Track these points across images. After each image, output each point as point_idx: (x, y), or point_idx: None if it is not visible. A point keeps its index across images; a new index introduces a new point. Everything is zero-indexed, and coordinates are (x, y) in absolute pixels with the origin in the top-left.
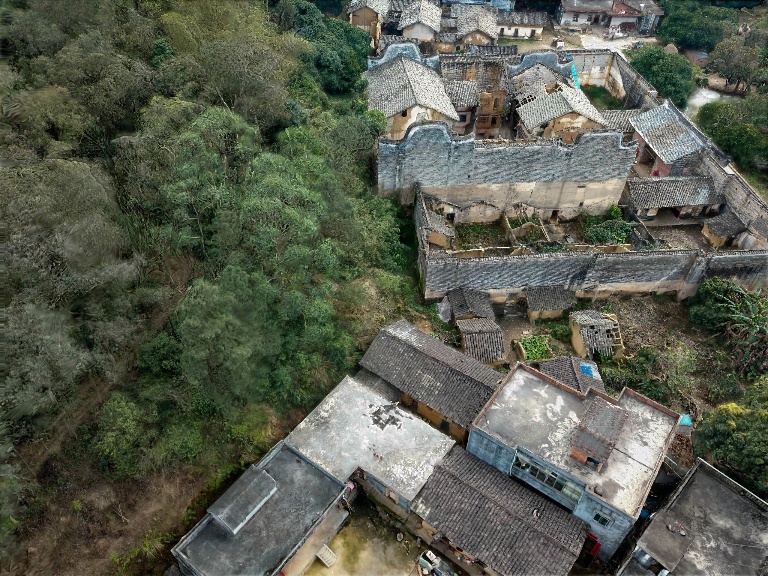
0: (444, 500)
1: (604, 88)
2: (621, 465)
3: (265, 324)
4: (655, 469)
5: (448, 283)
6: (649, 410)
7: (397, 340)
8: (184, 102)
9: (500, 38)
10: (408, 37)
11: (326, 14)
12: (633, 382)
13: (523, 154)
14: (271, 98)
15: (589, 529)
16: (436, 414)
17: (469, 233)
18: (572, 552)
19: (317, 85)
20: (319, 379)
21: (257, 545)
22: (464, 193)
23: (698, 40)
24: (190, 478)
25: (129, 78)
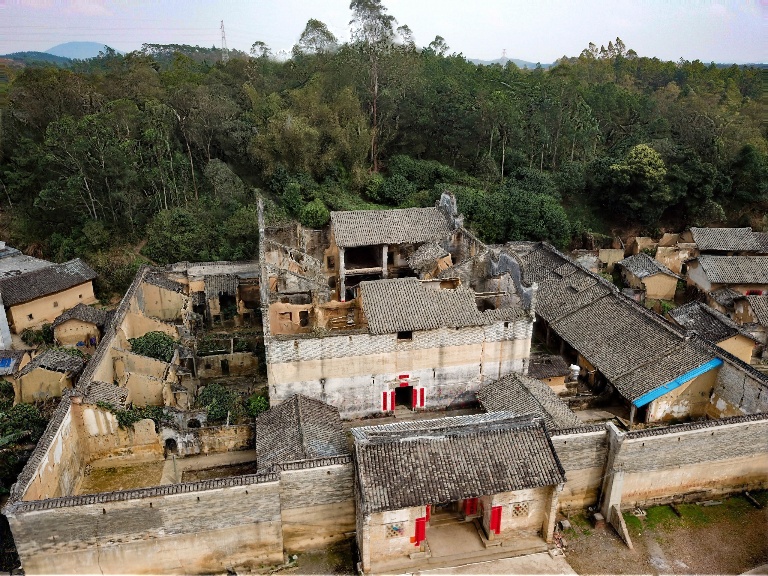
0: None
1: None
2: None
3: None
4: None
5: None
6: None
7: None
8: None
9: None
10: None
11: (658, 226)
12: None
13: None
14: None
15: None
16: None
17: None
18: None
19: None
20: None
21: None
22: None
23: None
24: None
25: (178, 96)
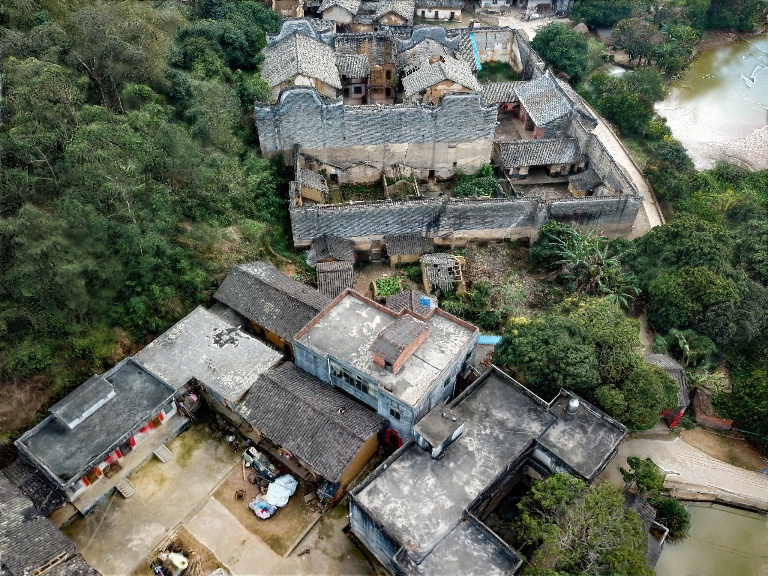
0: (263, 402)
1: (508, 64)
2: (416, 368)
3: (107, 252)
4: (442, 370)
5: (313, 231)
6: (453, 326)
7: (246, 274)
8: (40, 61)
9: (422, 20)
10: (326, 19)
11: None
12: (470, 313)
13: (391, 116)
14: (145, 65)
15: (387, 423)
16: (272, 335)
17: (352, 192)
18: (360, 437)
19: (220, 61)
20: (173, 308)
21: (90, 437)
22: (343, 154)
23: (606, 19)
24: (40, 386)
25: None
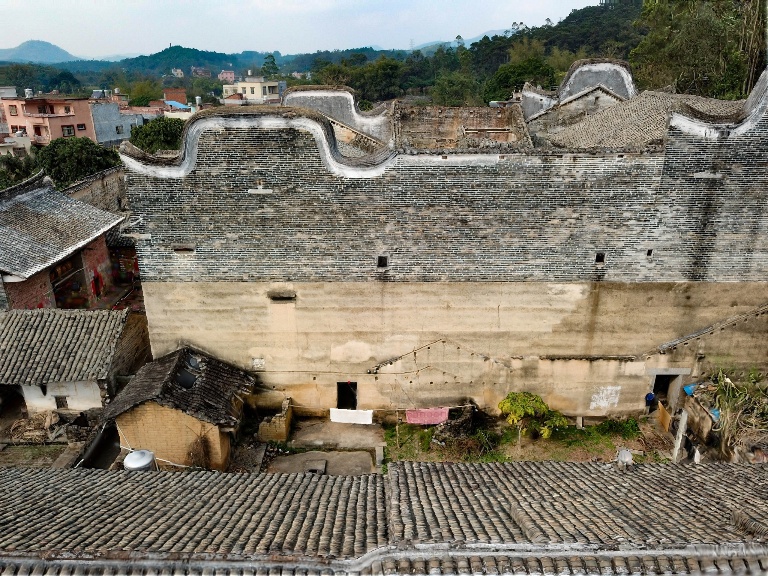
0: None
1: None
2: None
3: None
4: None
5: None
6: None
7: None
8: None
9: None
10: None
11: None
12: None
13: None
14: None
15: None
16: None
17: None
18: None
19: None
20: None
21: None
22: None
23: None
24: None
25: None
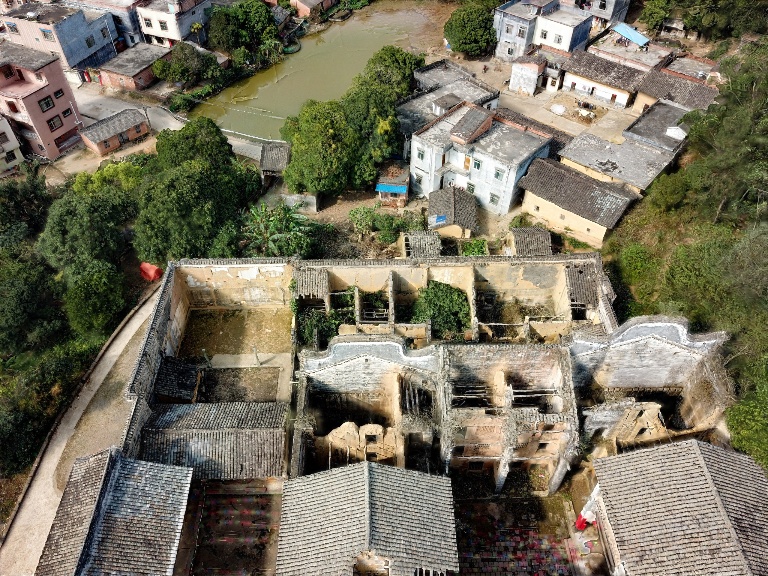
0: None
1: None
2: None
3: None
4: None
5: None
6: None
7: None
8: None
9: None
10: None
11: None
12: None
13: None
14: None
15: None
16: None
17: None
18: None
19: None
20: None
21: (664, 118)
22: None
23: None
24: None
25: None
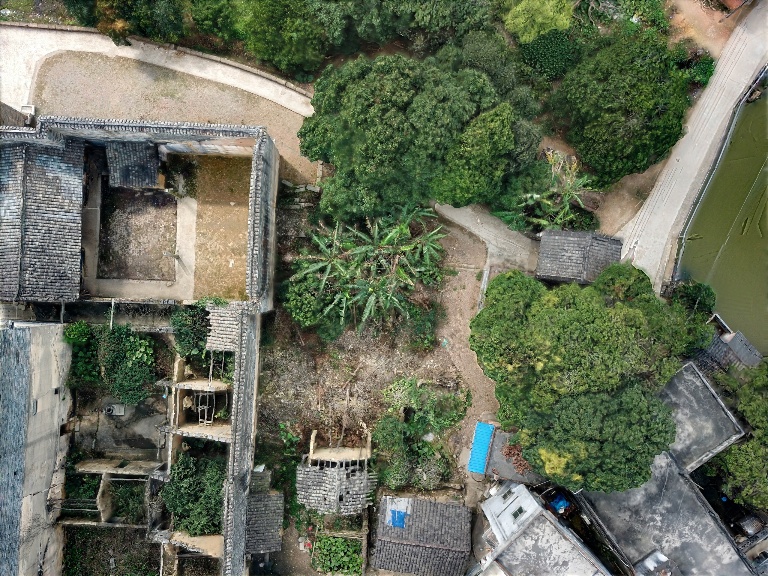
0: None
1: None
2: None
3: None
4: None
5: None
6: (523, 538)
7: None
8: None
9: None
10: None
11: None
12: None
13: None
14: None
15: None
16: None
17: (82, 570)
18: None
19: None
20: None
21: None
22: None
23: None
24: None
25: None
